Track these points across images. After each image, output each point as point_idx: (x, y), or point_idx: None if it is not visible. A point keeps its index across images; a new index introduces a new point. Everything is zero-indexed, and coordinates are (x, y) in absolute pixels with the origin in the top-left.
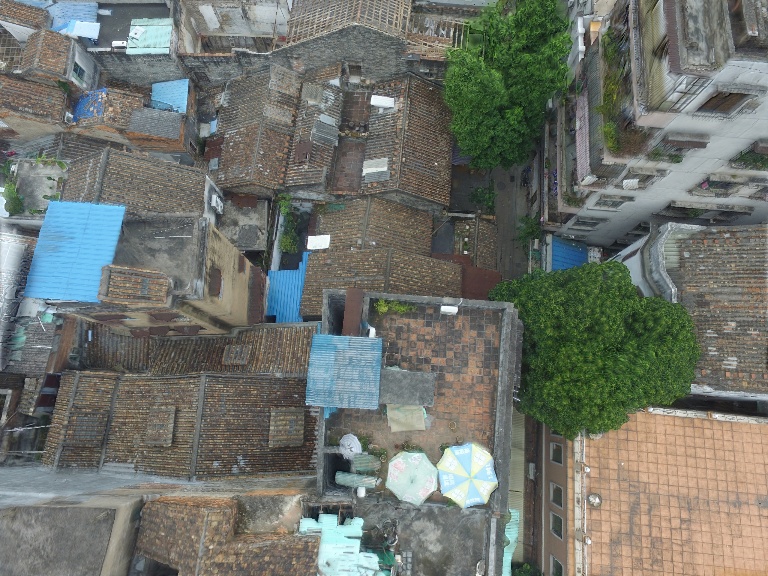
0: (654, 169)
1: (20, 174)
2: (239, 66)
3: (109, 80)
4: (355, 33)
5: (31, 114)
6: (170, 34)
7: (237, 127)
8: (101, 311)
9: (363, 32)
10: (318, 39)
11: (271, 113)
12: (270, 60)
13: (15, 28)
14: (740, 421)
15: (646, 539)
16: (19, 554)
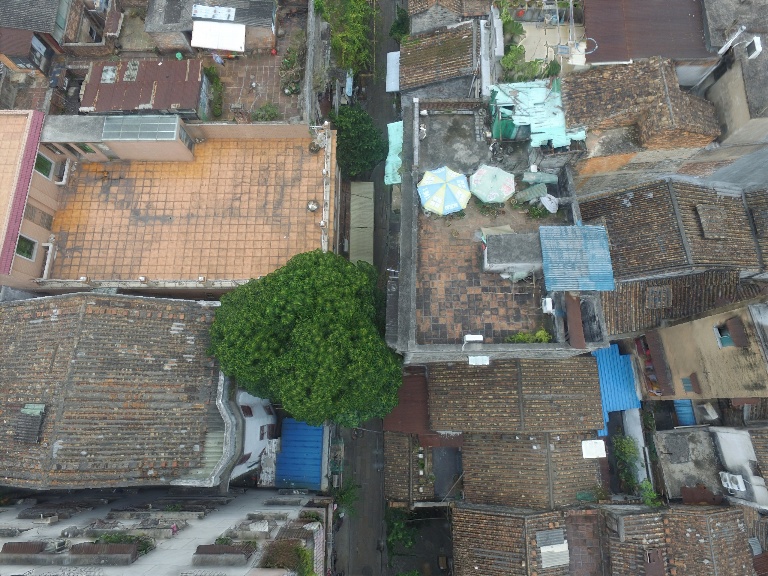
0: (240, 539)
1: None
2: None
3: None
4: None
5: None
6: None
7: None
8: None
9: None
10: None
11: None
12: None
13: None
14: None
15: (271, 184)
16: None
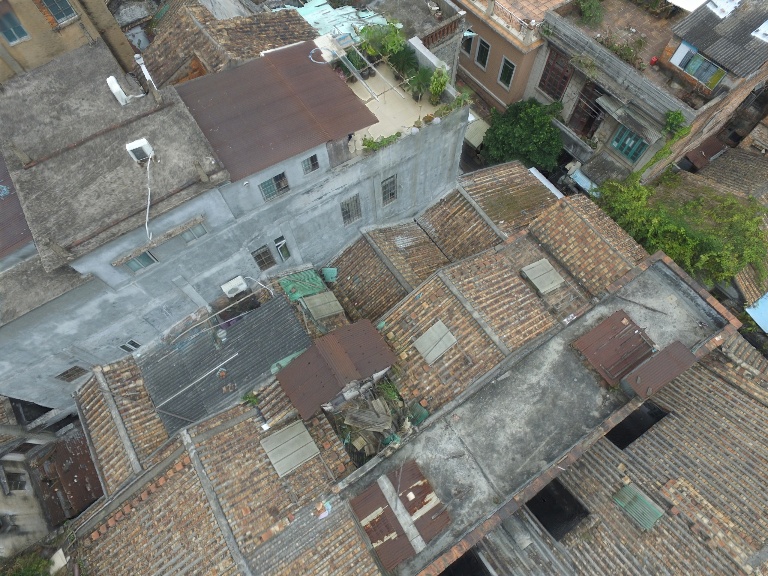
0: None
1: None
2: None
3: None
4: None
5: None
6: None
7: None
8: None
9: None
10: None
11: None
12: None
13: None
14: None
15: None
16: (30, 103)
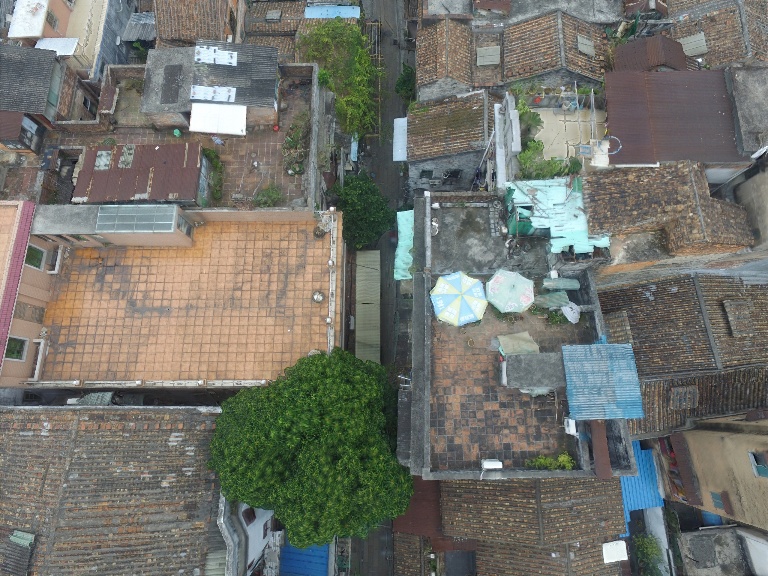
0: None
1: None
2: None
3: None
4: None
5: None
6: None
7: None
8: None
9: None
10: None
11: None
12: None
13: None
14: None
15: (274, 271)
16: None
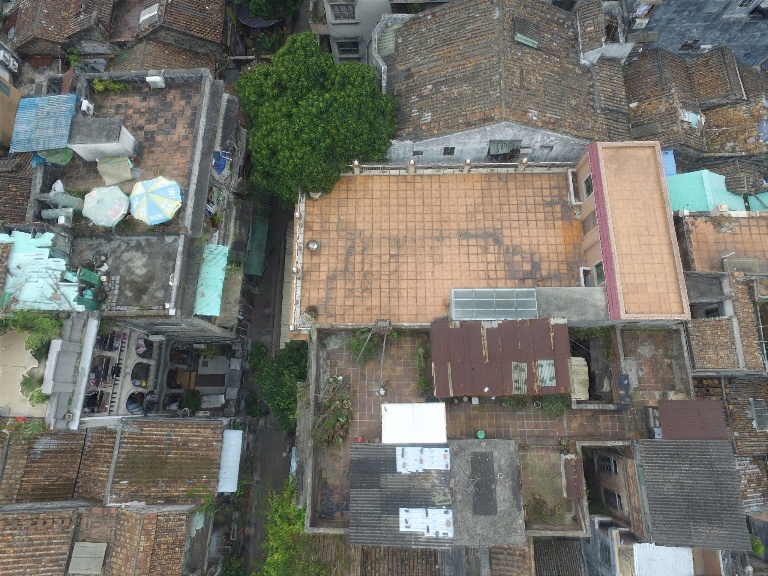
0: None
1: None
2: None
3: None
4: None
5: None
6: None
7: None
8: None
9: None
10: None
11: None
12: None
13: None
14: (446, 173)
15: (358, 273)
16: None
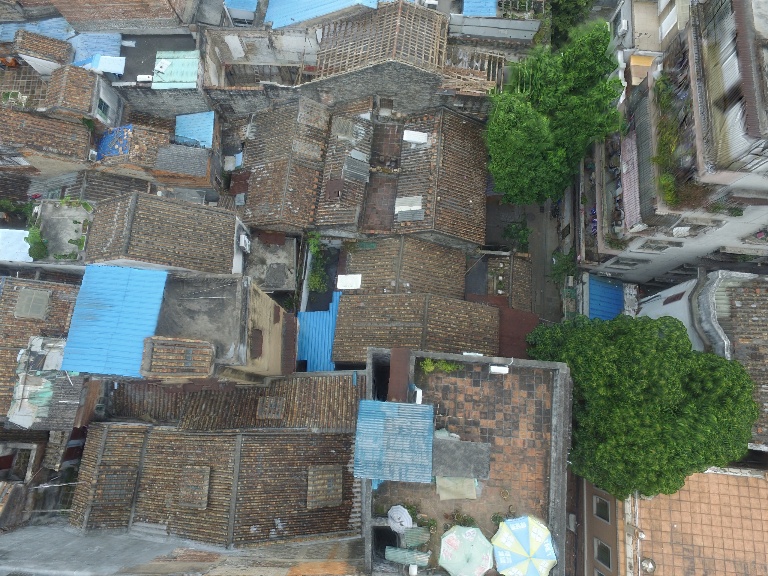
0: (709, 219)
1: (43, 216)
2: (266, 99)
3: (132, 113)
4: (390, 69)
5: (55, 154)
6: (197, 67)
7: (264, 162)
8: (139, 378)
9: (398, 68)
10: (351, 74)
11: (300, 148)
12: (299, 93)
13: (37, 62)
14: None
15: None
16: None
